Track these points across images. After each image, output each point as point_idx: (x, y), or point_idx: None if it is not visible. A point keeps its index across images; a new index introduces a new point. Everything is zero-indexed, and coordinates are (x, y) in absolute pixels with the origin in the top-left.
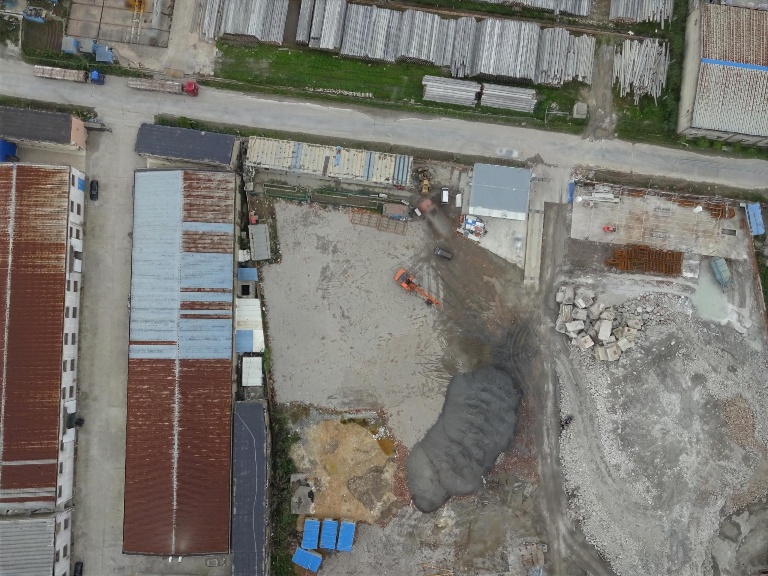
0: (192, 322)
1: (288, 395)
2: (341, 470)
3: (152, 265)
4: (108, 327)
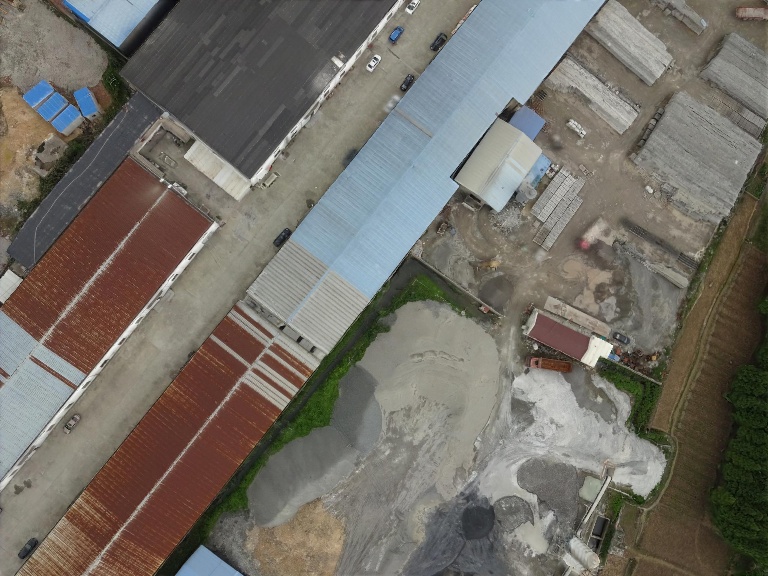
0: (3, 365)
1: (1, 245)
2: (3, 149)
3: (1, 441)
4: (110, 418)
